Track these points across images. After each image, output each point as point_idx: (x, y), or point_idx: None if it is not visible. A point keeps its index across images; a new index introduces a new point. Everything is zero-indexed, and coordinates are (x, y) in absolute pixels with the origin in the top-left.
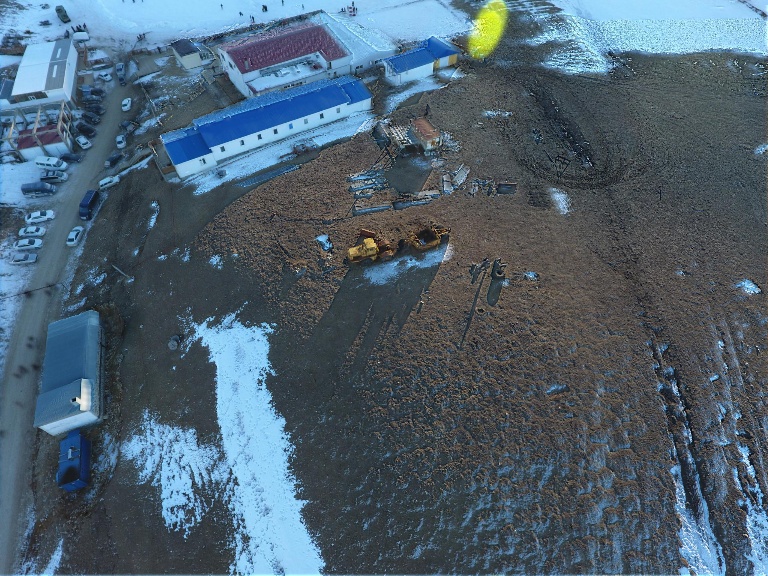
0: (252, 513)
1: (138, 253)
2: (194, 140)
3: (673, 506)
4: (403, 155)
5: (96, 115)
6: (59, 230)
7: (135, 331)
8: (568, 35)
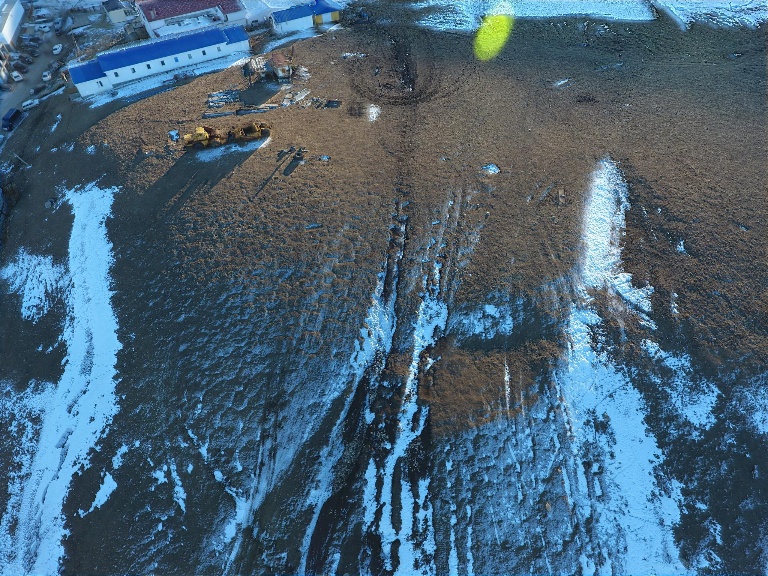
0: (79, 302)
1: (39, 149)
2: (93, 67)
3: (371, 294)
4: (261, 81)
5: (30, 56)
6: None
7: (24, 199)
8: (449, 1)
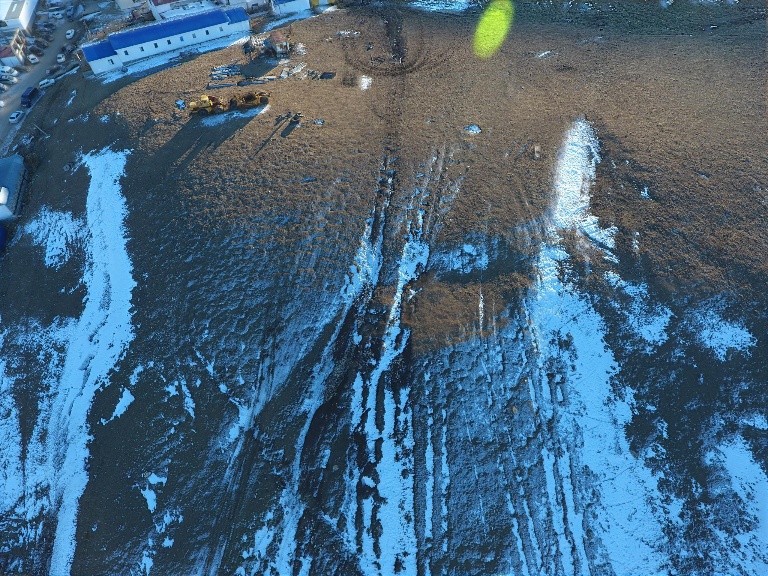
0: (97, 250)
1: (56, 121)
2: (105, 46)
3: (359, 237)
4: (260, 57)
5: (45, 40)
6: (6, 114)
7: (45, 164)
8: None
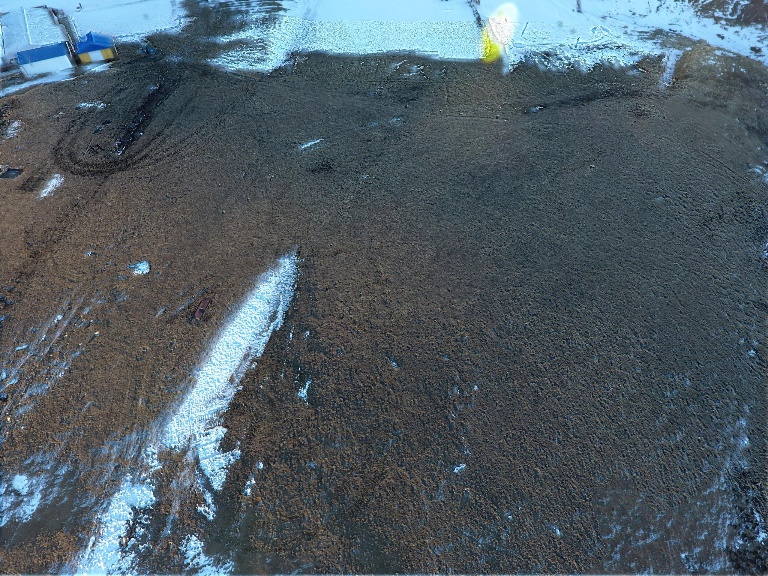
0: None
1: None
2: None
3: None
4: None
5: None
6: None
7: None
8: (261, 34)
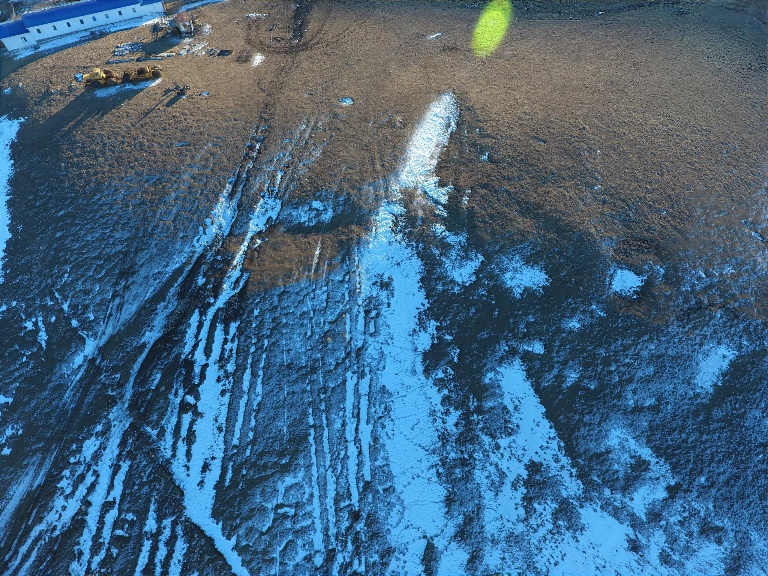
0: None
1: None
2: (18, 24)
3: (219, 194)
4: (166, 36)
5: None
6: None
7: None
8: None
